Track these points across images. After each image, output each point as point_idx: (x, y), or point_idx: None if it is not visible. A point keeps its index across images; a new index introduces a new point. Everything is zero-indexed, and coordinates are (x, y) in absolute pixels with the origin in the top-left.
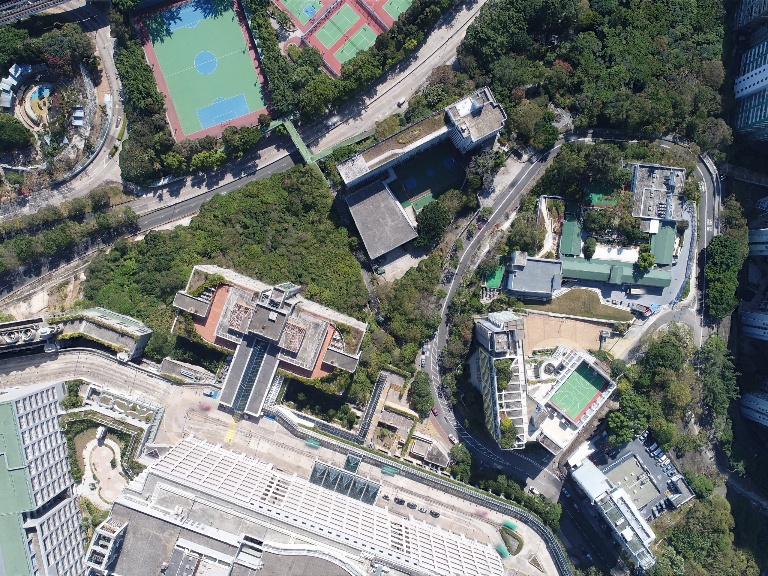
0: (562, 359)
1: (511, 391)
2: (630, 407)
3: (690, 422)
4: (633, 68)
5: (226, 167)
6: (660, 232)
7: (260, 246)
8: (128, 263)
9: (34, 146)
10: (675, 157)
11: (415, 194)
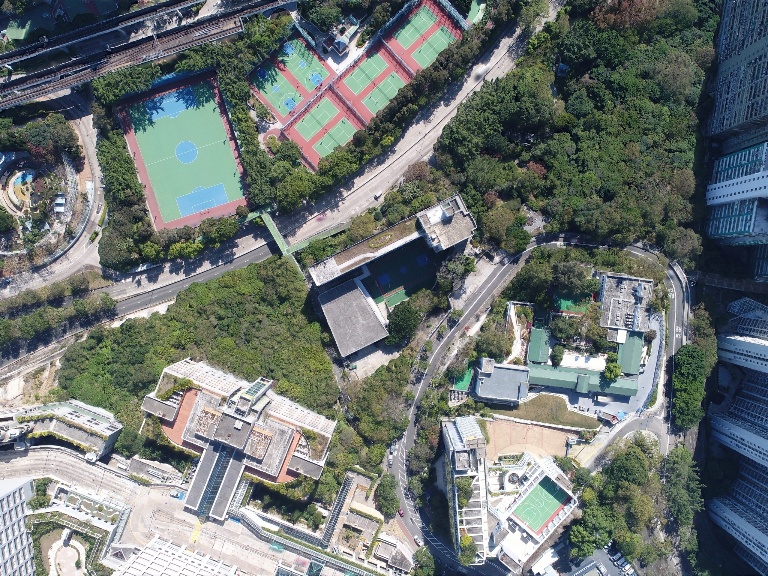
0: (526, 470)
1: (472, 508)
2: (592, 523)
3: (656, 529)
4: (605, 176)
5: (204, 255)
6: (627, 342)
7: (233, 339)
8: (103, 351)
9: (16, 230)
10: (643, 268)
11: (388, 290)
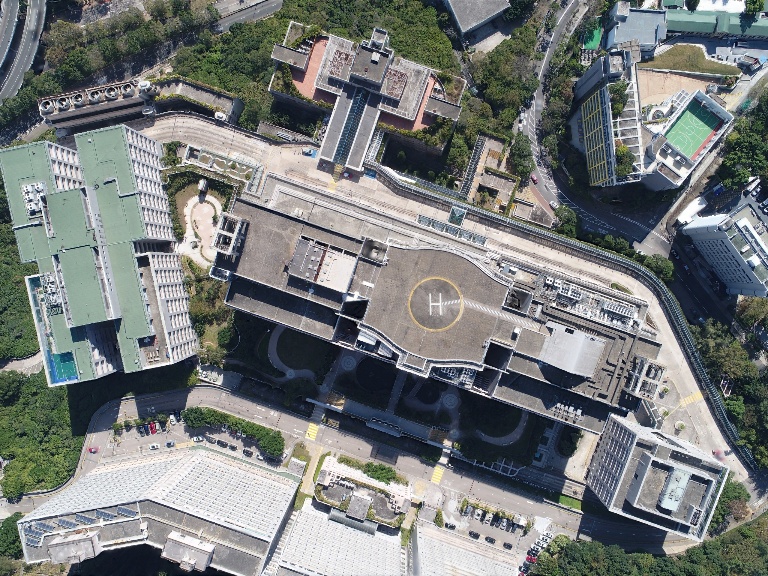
0: None
1: (626, 118)
2: (748, 142)
3: None
4: None
5: None
6: None
7: (347, 30)
8: (213, 55)
9: None
10: None
11: None
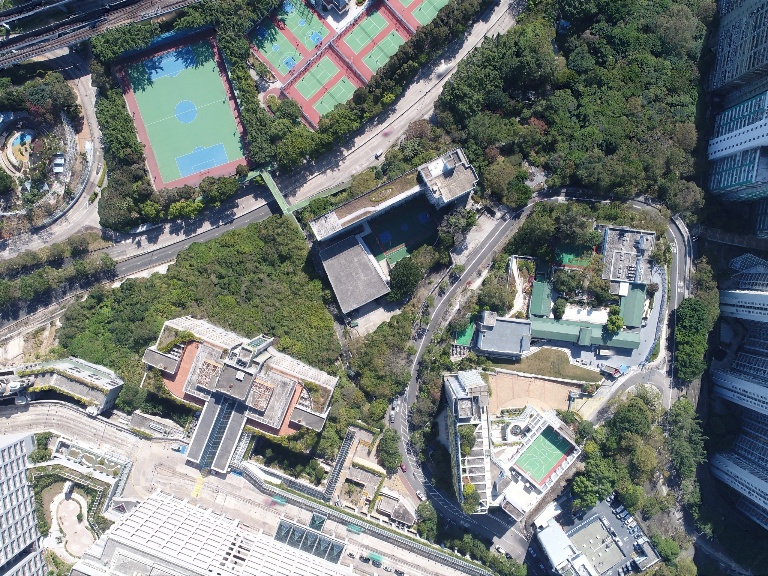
0: (528, 421)
1: (474, 456)
2: (594, 472)
3: (658, 483)
4: (606, 129)
5: (204, 215)
6: (630, 294)
7: (234, 297)
8: (104, 311)
9: (15, 191)
10: (646, 220)
11: (389, 248)
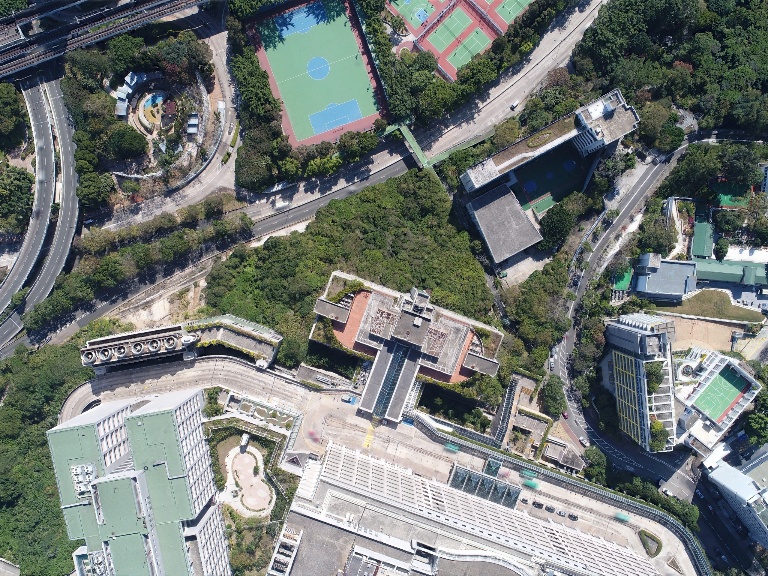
0: (701, 361)
1: (661, 394)
2: None
3: None
4: (759, 68)
5: (339, 172)
6: None
7: (381, 251)
8: (248, 270)
9: (147, 154)
10: None
11: (535, 197)
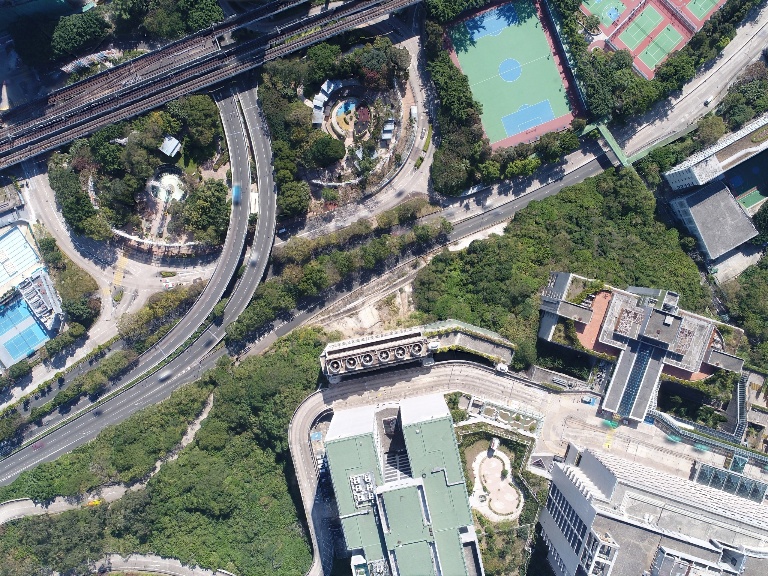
0: None
1: None
2: None
3: None
4: None
5: (533, 174)
6: None
7: (590, 251)
8: (454, 274)
9: (340, 161)
10: None
11: (741, 192)
